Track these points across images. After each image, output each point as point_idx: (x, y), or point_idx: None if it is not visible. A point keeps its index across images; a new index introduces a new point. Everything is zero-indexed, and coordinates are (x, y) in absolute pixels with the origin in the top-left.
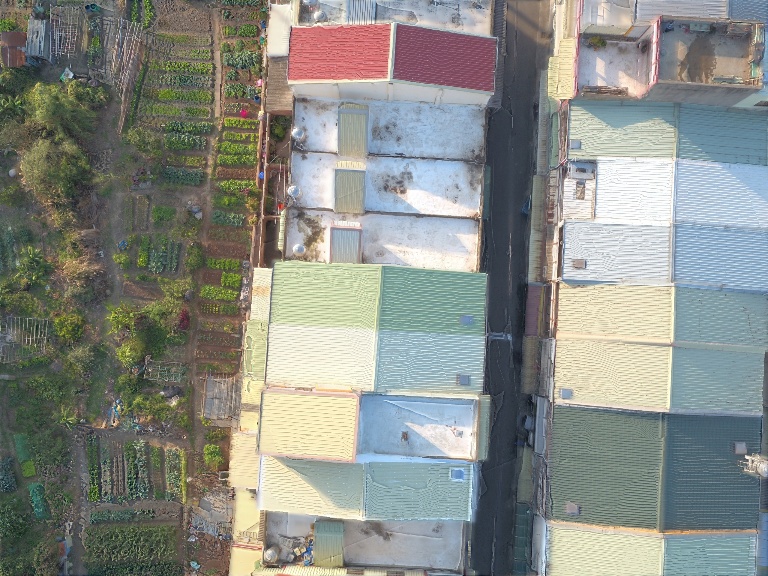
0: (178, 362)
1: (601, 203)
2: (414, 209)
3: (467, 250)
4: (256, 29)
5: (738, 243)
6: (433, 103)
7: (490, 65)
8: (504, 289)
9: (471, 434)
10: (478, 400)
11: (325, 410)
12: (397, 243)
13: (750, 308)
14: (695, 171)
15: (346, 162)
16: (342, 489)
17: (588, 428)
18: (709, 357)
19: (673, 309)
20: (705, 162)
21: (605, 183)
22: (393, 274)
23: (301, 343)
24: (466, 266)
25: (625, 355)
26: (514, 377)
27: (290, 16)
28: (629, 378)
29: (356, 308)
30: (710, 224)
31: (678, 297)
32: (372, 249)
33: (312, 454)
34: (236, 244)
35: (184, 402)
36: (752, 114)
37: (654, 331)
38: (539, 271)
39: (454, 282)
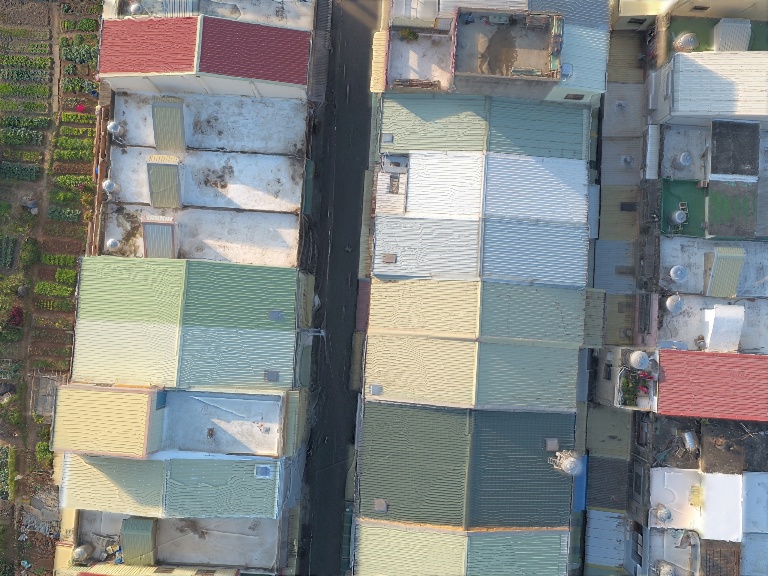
0: (7, 359)
1: (412, 197)
2: (234, 204)
3: (288, 245)
4: (95, 23)
5: (550, 238)
6: (255, 97)
7: (303, 58)
8: (343, 285)
9: (277, 431)
10: (286, 396)
11: (118, 406)
12: (217, 238)
13: (563, 303)
14: (506, 165)
15: (159, 156)
16: (139, 486)
17: (407, 425)
18: (517, 353)
19: (479, 304)
20: (517, 156)
21: (415, 177)
22: (197, 269)
23: (99, 338)
24: (287, 261)
25: (433, 351)
26: (343, 374)
27: (114, 9)
28: (437, 374)
29: (153, 303)
30: (521, 218)
31: (484, 292)
32: (191, 244)
33: (105, 451)
34: (72, 240)
35: (16, 399)
36: (567, 108)
37: (463, 326)
38: (368, 267)
39: (263, 277)
